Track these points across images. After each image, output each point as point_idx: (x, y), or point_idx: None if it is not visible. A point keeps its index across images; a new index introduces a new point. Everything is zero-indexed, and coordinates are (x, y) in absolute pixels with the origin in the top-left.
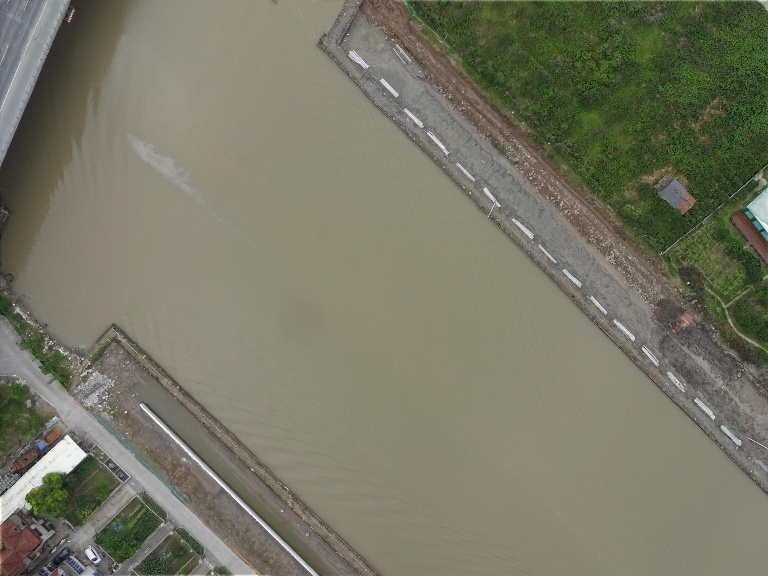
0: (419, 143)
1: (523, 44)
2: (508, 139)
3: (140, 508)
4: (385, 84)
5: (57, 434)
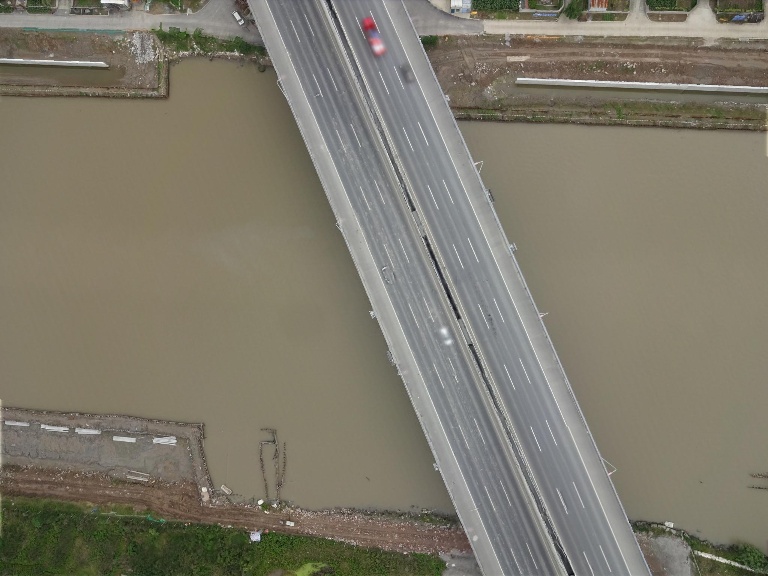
0: (66, 414)
1: (41, 568)
2: (6, 480)
3: (48, 2)
4: (130, 439)
5: (135, 0)
